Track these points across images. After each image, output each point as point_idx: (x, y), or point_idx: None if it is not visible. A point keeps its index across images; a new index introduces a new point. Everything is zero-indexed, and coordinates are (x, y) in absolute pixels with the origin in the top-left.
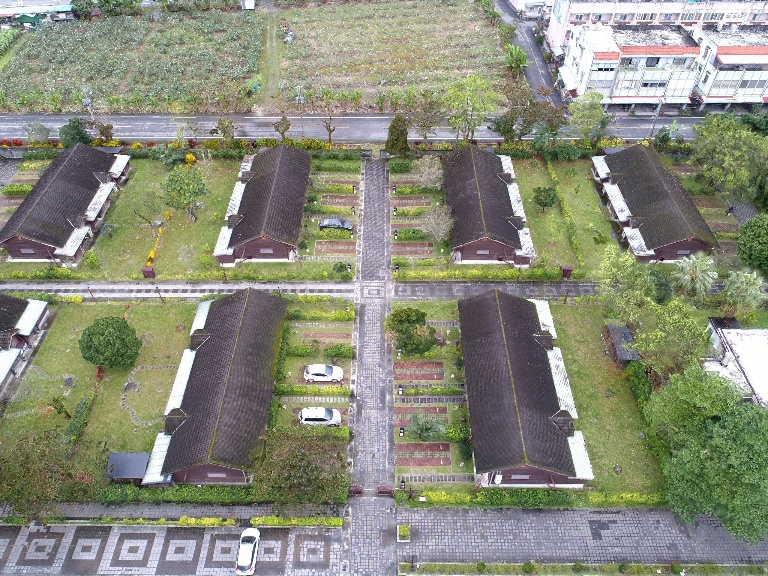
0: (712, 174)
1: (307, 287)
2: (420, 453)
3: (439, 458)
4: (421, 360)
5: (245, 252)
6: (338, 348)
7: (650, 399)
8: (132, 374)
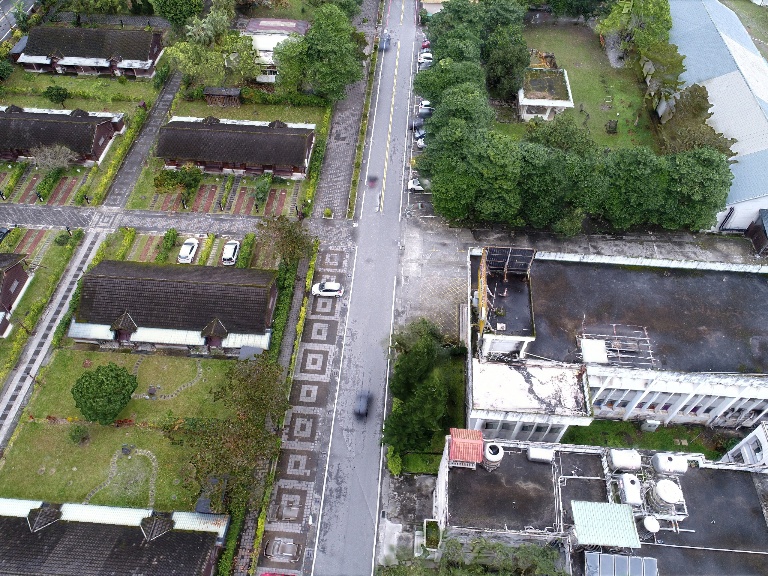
0: (102, 2)
1: (76, 266)
2: (274, 203)
3: (280, 195)
4: (195, 196)
5: (4, 306)
6: (168, 237)
7: None
8: (135, 396)
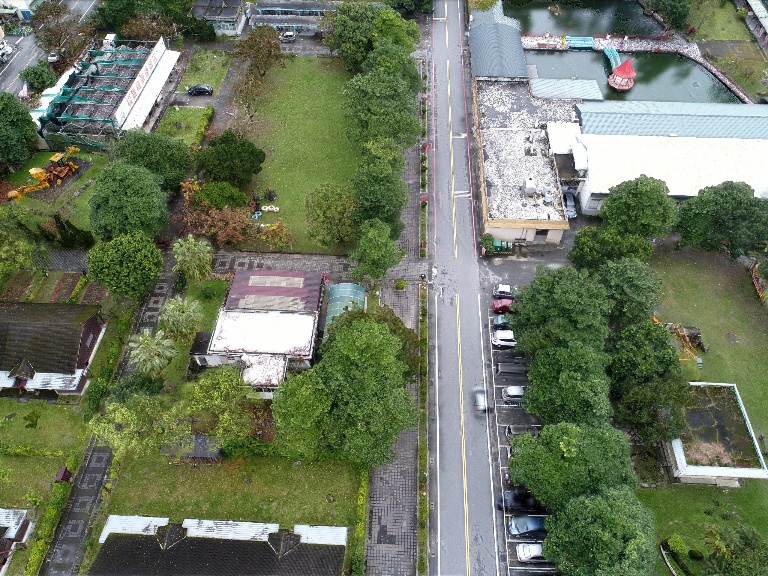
0: (4, 271)
1: None
2: None
3: None
4: None
5: None
6: None
7: (265, 442)
8: None
